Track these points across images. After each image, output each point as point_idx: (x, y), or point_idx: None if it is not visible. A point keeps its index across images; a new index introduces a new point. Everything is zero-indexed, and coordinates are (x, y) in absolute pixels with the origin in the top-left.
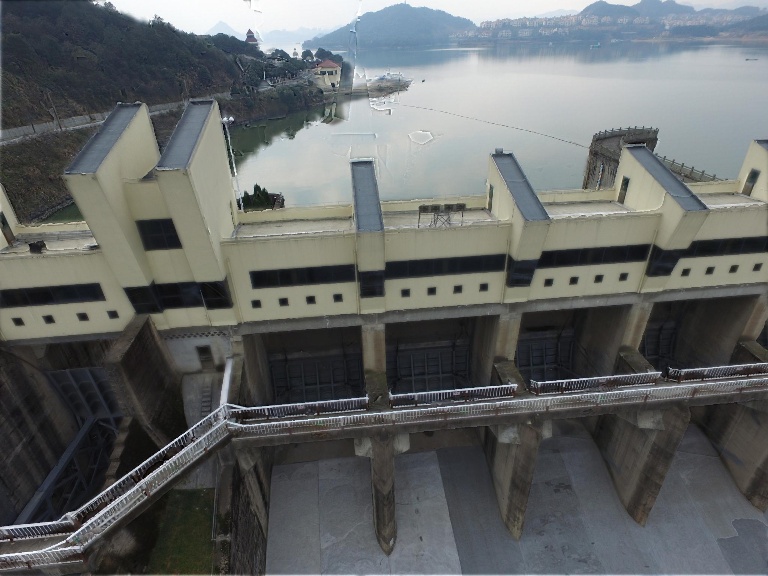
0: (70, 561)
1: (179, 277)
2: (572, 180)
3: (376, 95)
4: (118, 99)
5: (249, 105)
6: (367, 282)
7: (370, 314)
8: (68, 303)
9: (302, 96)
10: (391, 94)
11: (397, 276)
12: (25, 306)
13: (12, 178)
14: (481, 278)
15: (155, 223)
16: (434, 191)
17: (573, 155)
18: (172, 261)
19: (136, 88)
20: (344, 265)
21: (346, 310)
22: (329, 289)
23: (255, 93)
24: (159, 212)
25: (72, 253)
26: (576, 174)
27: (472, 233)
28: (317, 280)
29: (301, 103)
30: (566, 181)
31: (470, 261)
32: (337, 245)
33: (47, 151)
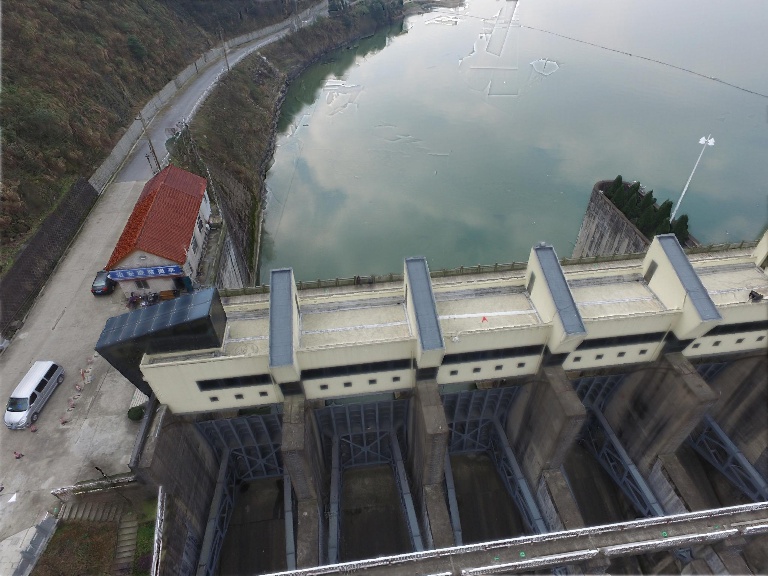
0: None
1: None
2: (755, 132)
3: (452, 4)
4: (236, 23)
5: (348, 24)
6: None
7: None
8: (740, 333)
9: (386, 9)
10: (466, 3)
11: None
12: (711, 336)
13: (235, 134)
14: None
15: None
16: (621, 142)
17: (755, 104)
18: None
19: (249, 9)
20: None
21: None
22: None
23: (348, 8)
24: None
25: None
26: (758, 125)
27: None
28: None
29: (385, 17)
30: (749, 133)
31: None
32: None
33: (233, 98)
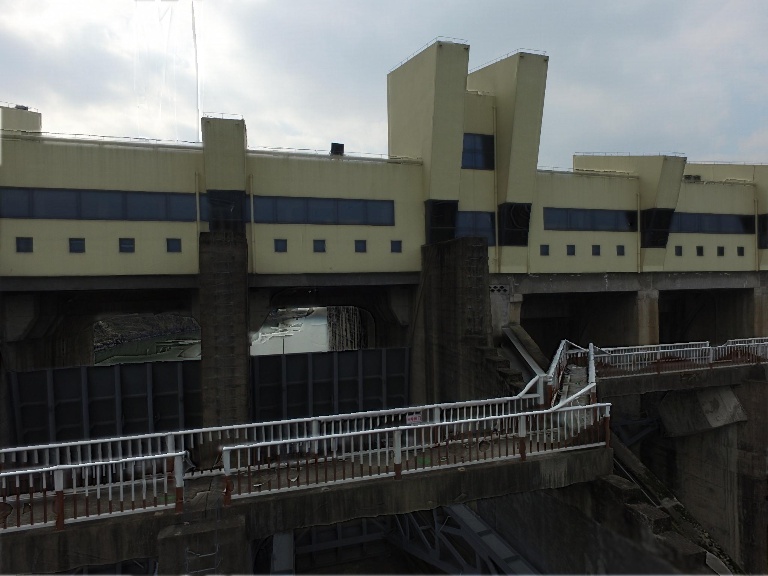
0: (585, 444)
1: (476, 205)
2: None
3: None
4: None
5: None
6: (657, 224)
7: (645, 276)
8: (350, 225)
9: None
10: None
11: (670, 230)
12: (297, 223)
13: None
14: (737, 240)
15: (467, 137)
16: None
17: None
18: (474, 184)
19: None
20: (627, 211)
21: (626, 267)
22: (613, 238)
23: None
24: (474, 126)
25: (377, 159)
26: None
27: (727, 190)
28: (602, 227)
29: None
30: None
31: (727, 220)
32: (623, 187)
33: None
